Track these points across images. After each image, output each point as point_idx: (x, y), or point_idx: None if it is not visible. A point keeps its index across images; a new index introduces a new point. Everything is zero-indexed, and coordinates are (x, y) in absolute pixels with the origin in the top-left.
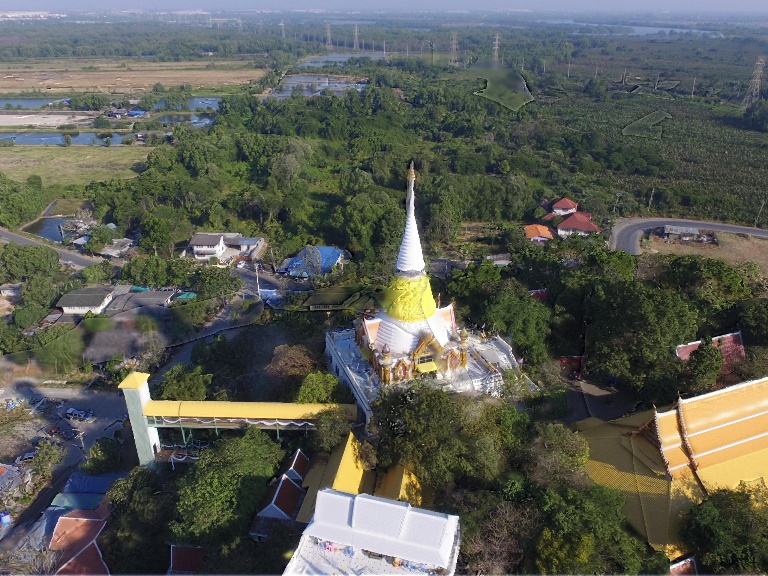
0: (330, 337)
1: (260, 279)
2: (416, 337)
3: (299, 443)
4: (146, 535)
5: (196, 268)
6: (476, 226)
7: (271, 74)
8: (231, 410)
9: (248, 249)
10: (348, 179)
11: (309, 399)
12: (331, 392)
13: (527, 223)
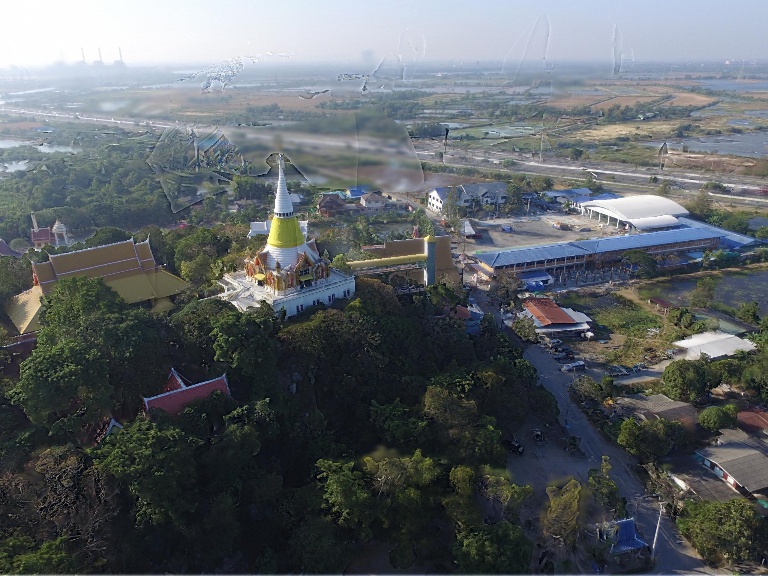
0: None
1: None
2: None
3: None
4: None
5: None
6: None
7: None
8: None
9: None
10: None
11: None
12: None
13: None
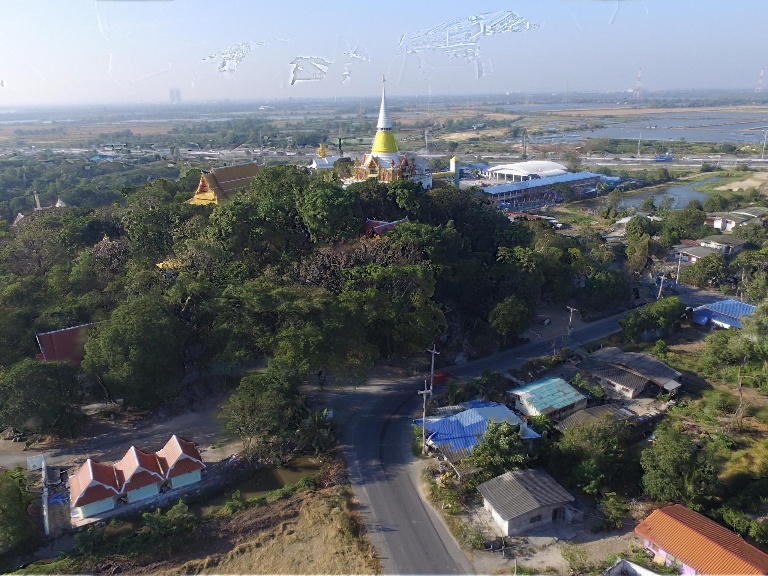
0: None
1: None
2: None
3: None
4: None
5: (745, 261)
6: None
7: None
8: None
9: None
10: None
11: None
12: None
13: None
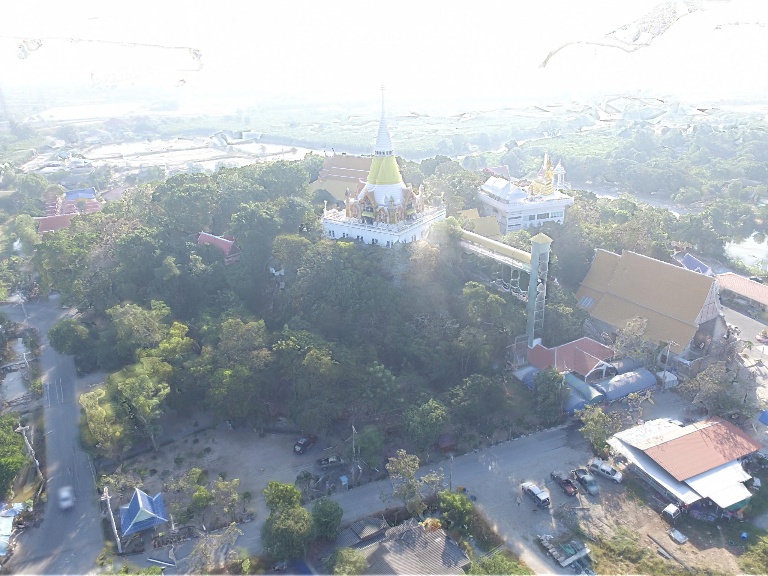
0: None
1: None
2: None
3: None
4: None
5: None
6: None
7: None
8: None
9: None
10: None
11: None
12: None
13: None
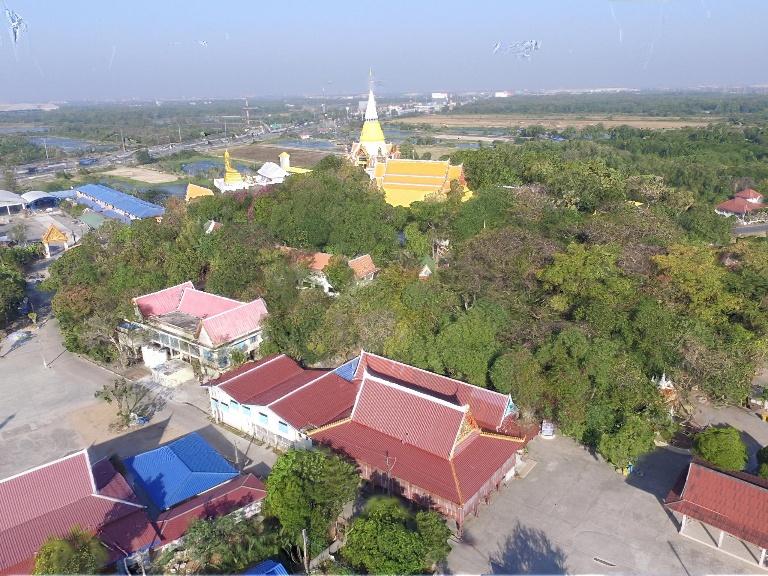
0: None
1: None
2: None
3: None
4: None
5: None
6: None
7: (720, 122)
8: None
9: None
10: None
11: None
12: None
13: None
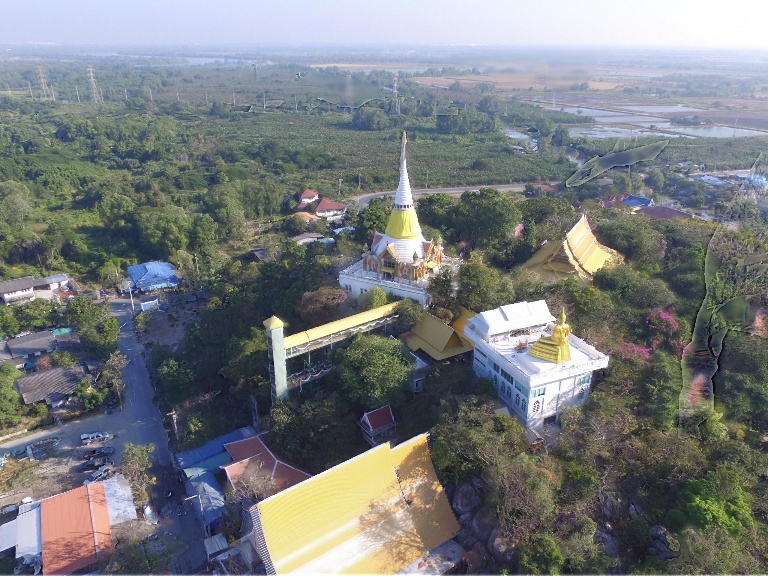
0: (346, 273)
1: (110, 303)
2: (422, 247)
3: (382, 336)
4: (339, 421)
5: (49, 306)
6: (249, 224)
7: None
8: (341, 325)
9: (59, 286)
10: (109, 206)
11: (379, 304)
12: (386, 297)
13: (285, 214)
